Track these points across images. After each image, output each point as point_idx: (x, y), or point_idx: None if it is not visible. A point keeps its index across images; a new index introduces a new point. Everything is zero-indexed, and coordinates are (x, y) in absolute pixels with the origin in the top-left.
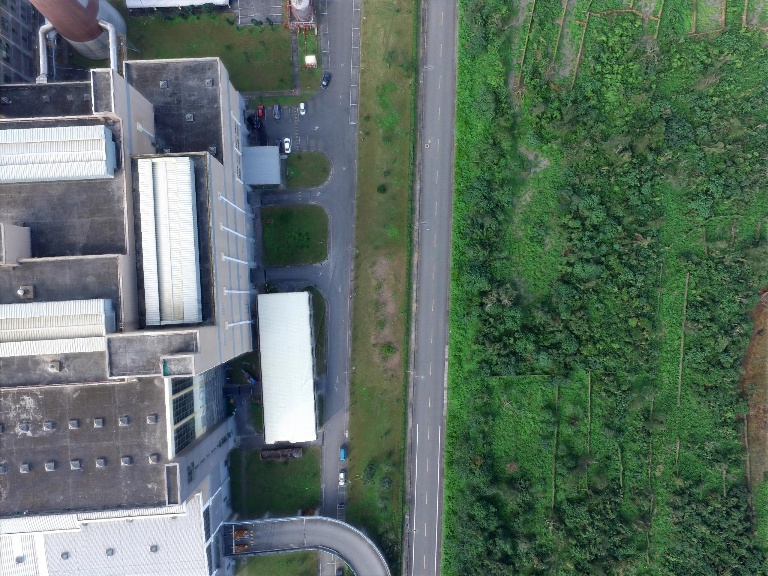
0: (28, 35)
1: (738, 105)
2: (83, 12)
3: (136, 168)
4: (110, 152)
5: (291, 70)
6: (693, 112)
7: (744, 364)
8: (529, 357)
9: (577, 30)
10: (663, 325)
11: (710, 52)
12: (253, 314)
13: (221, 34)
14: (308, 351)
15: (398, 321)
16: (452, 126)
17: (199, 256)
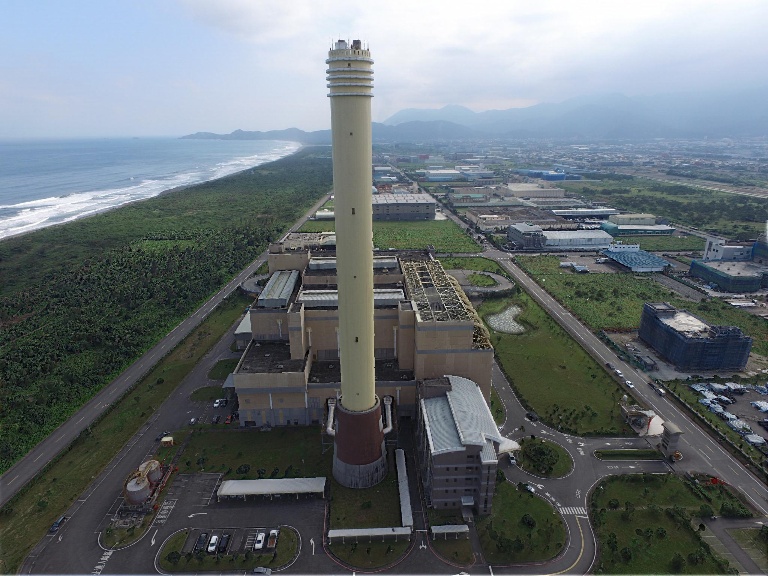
0: None
1: None
2: None
3: None
4: None
5: None
6: None
7: None
8: None
9: None
10: None
11: None
12: None
13: None
14: None
15: None
16: None
17: None
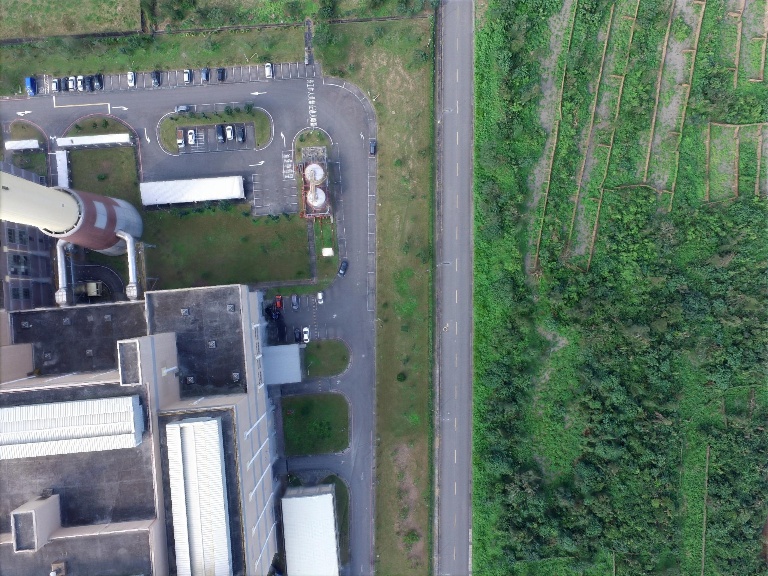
0: (44, 235)
1: (753, 276)
2: (102, 233)
3: (163, 424)
4: (138, 419)
5: (308, 259)
6: (709, 283)
7: (766, 529)
8: (553, 541)
9: (591, 206)
10: (685, 499)
11: (724, 223)
12: (277, 515)
13: (237, 225)
14: (333, 554)
15: (421, 507)
16: (470, 308)
17: (228, 512)
